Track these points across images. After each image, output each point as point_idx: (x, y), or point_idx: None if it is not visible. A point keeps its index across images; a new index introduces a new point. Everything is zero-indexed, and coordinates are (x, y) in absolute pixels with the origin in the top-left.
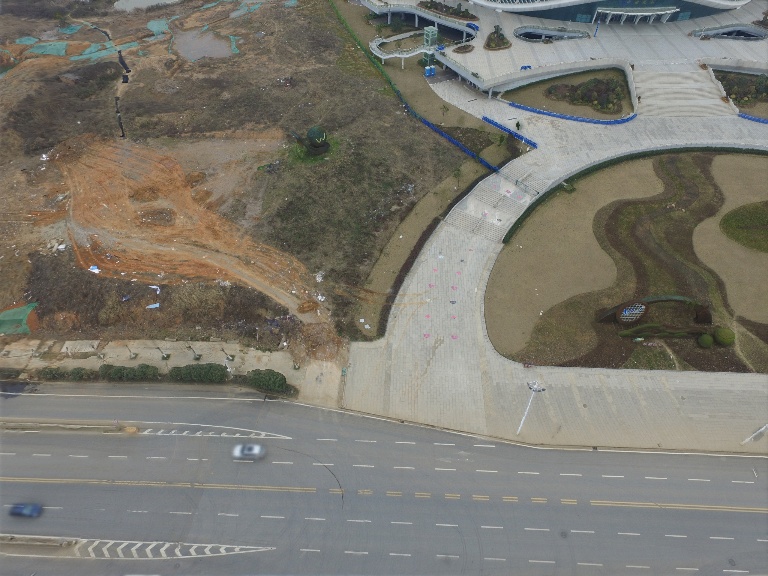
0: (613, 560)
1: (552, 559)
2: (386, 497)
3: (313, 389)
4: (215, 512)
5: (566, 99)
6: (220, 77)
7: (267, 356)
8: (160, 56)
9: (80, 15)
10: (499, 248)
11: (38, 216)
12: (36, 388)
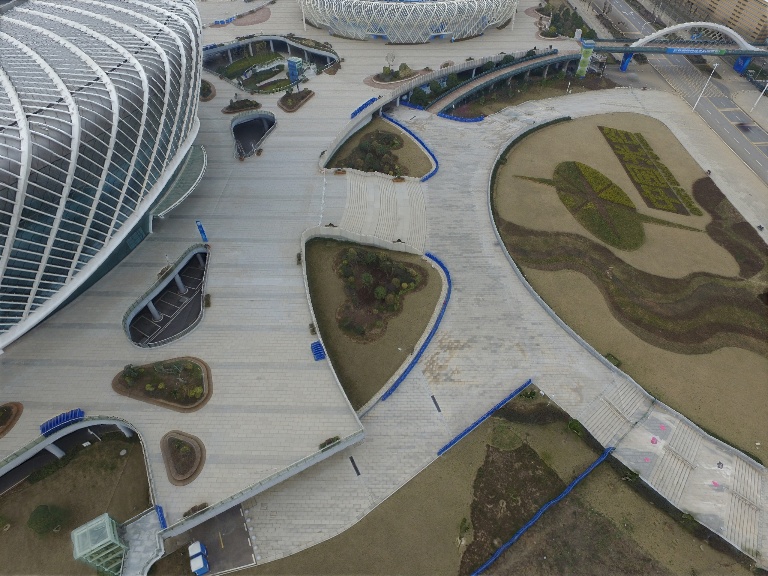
0: None
1: None
2: None
3: None
4: None
5: (383, 317)
6: None
7: None
8: None
9: None
10: None
11: None
12: None
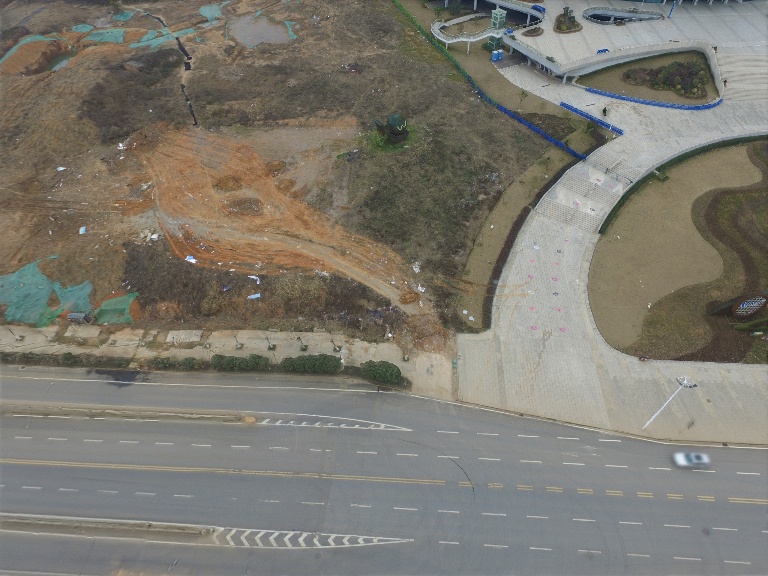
0: (761, 559)
1: (697, 556)
2: (517, 491)
3: (426, 381)
4: (347, 503)
5: (646, 84)
6: (282, 63)
7: (374, 347)
8: (219, 42)
9: (131, 1)
10: (595, 238)
11: (125, 205)
12: (147, 377)
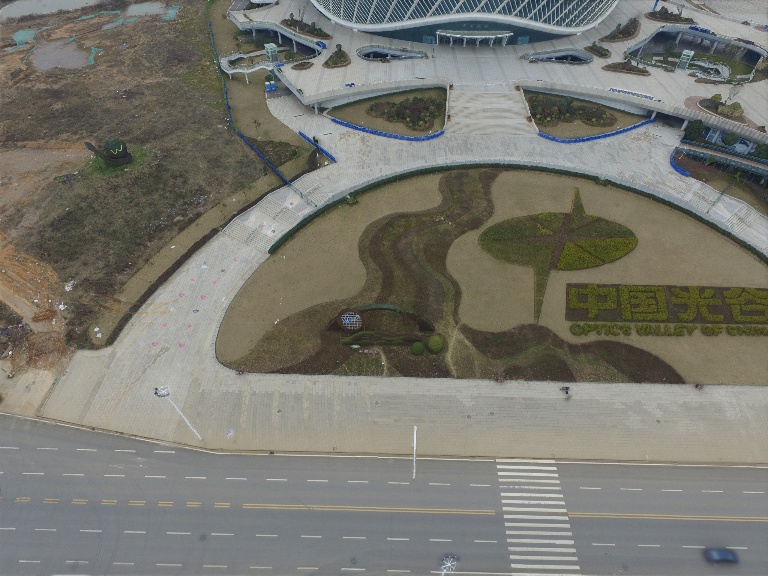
0: (240, 561)
1: (180, 562)
2: (41, 504)
3: (18, 398)
4: None
5: (384, 116)
6: (62, 88)
7: None
8: (9, 66)
9: None
10: (264, 258)
11: None
12: None
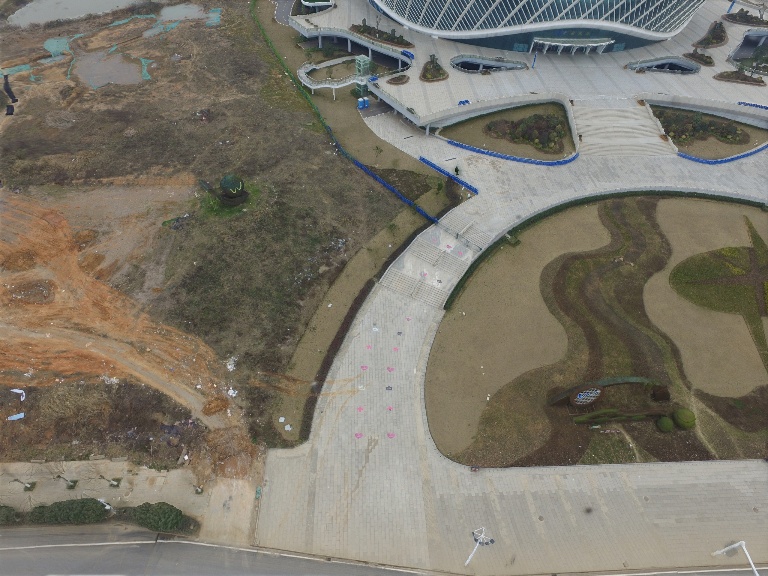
0: None
1: None
2: None
3: (219, 521)
4: None
5: (506, 137)
6: (126, 108)
7: (162, 477)
8: (55, 82)
9: None
10: (440, 316)
11: None
12: None
